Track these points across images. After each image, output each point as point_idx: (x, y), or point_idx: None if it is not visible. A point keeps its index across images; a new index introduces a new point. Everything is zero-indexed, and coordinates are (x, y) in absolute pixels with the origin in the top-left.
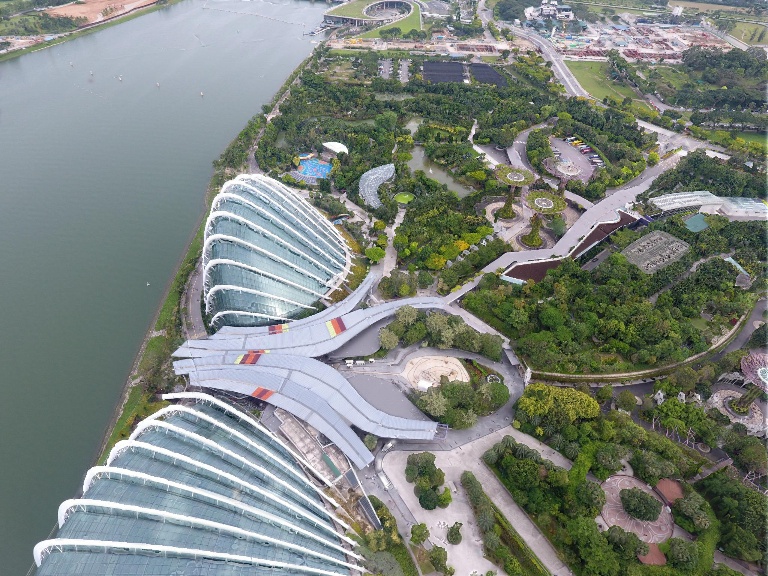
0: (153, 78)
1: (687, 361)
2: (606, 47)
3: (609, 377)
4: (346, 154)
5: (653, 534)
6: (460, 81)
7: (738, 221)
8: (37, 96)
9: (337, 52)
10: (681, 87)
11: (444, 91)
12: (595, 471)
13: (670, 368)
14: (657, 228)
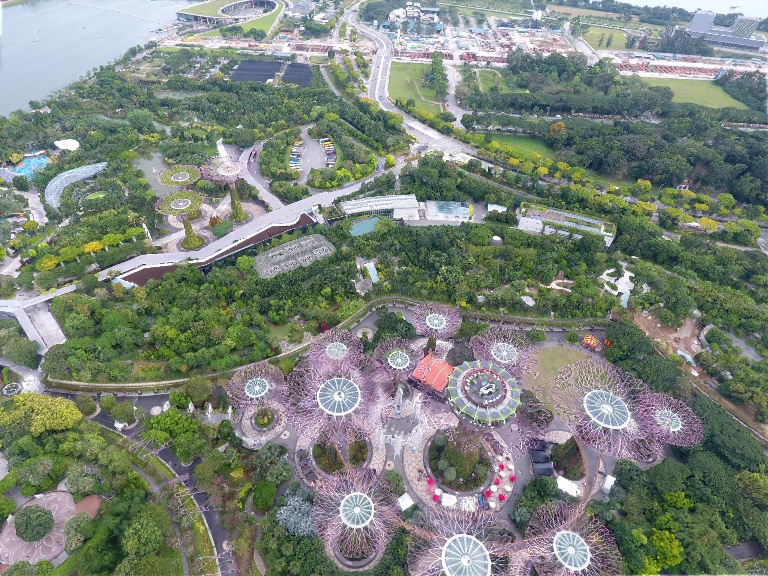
0: None
1: (237, 370)
2: (447, 50)
3: (132, 386)
4: (65, 152)
5: (37, 555)
6: (264, 80)
7: (405, 225)
8: None
9: (163, 49)
10: (489, 90)
11: (237, 90)
12: (21, 487)
13: (210, 377)
14: (318, 231)
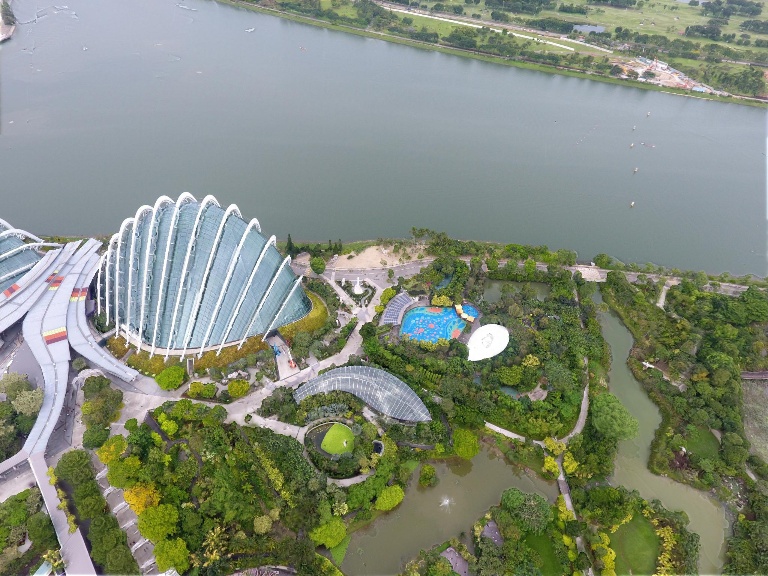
0: (655, 164)
1: None
2: None
3: None
4: (452, 350)
5: None
6: None
7: None
8: (558, 115)
9: None
10: None
11: None
12: None
13: None
14: None
